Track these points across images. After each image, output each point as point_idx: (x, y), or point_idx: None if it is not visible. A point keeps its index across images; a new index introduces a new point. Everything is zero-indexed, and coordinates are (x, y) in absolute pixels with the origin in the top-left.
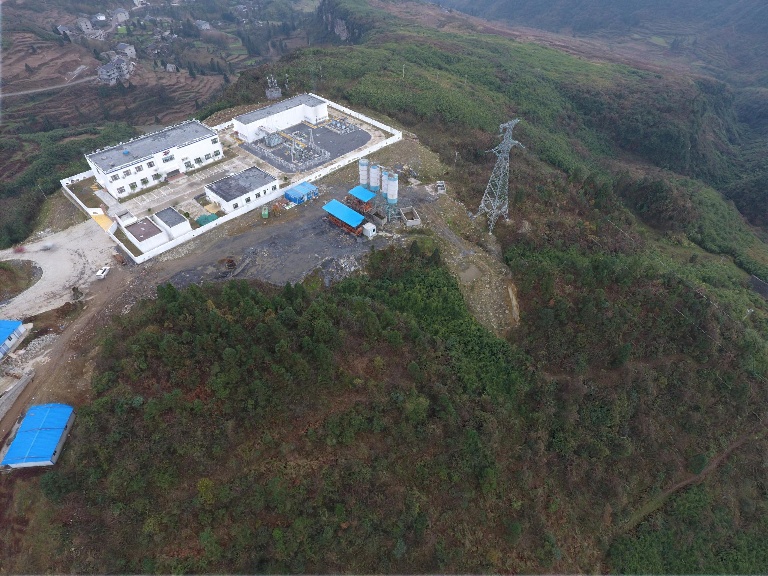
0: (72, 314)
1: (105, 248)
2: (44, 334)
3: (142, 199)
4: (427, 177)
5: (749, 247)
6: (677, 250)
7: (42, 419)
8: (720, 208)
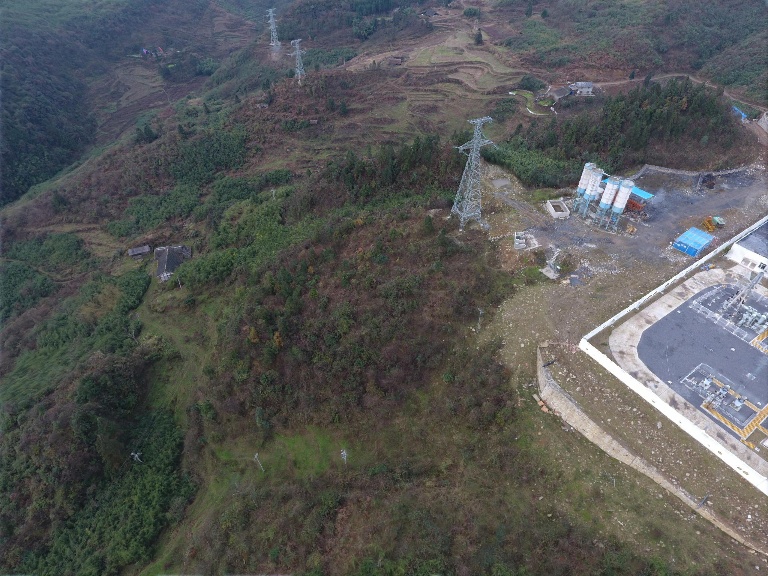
0: None
1: None
2: None
3: None
4: (532, 279)
5: (65, 343)
6: (175, 332)
7: None
8: (6, 395)
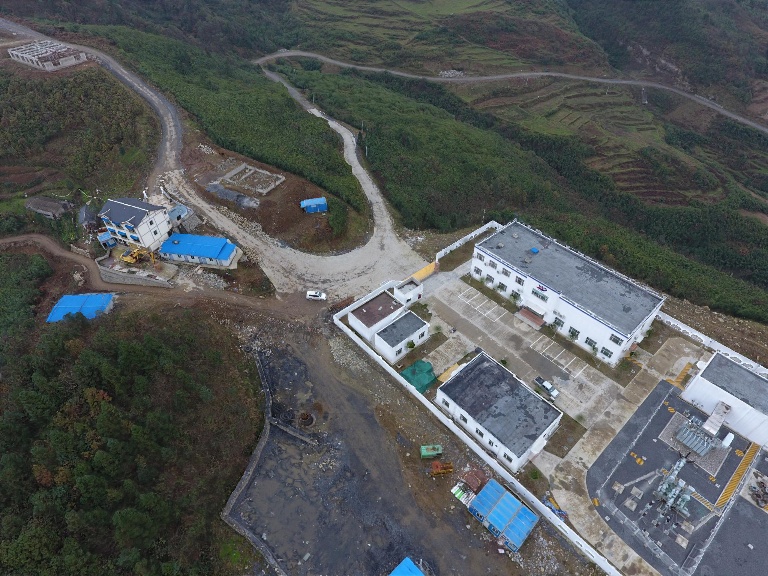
0: (255, 291)
1: (370, 288)
2: (226, 279)
3: (471, 295)
4: None
5: None
6: None
7: (92, 305)
8: None
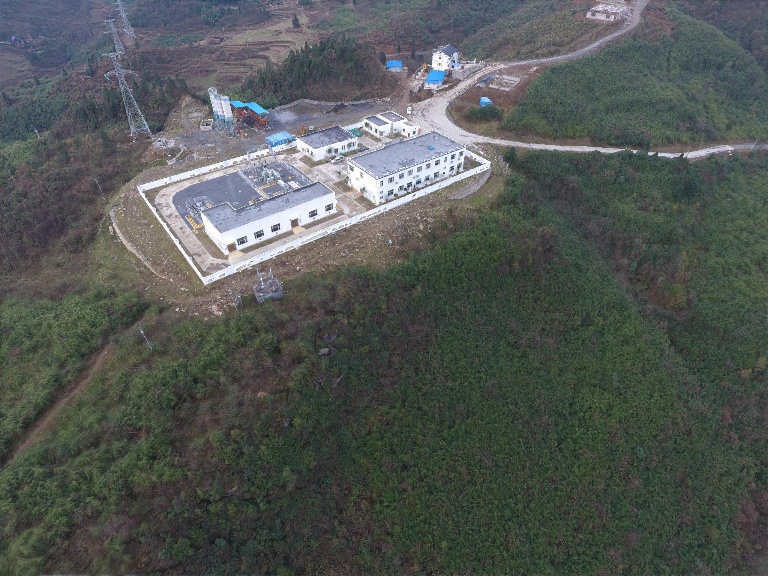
0: None
1: None
2: None
3: None
4: None
5: None
6: None
7: None
8: None
